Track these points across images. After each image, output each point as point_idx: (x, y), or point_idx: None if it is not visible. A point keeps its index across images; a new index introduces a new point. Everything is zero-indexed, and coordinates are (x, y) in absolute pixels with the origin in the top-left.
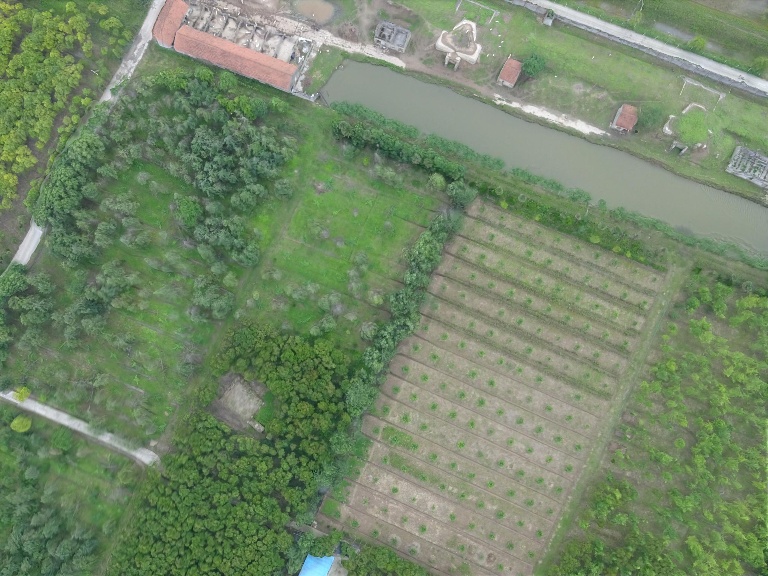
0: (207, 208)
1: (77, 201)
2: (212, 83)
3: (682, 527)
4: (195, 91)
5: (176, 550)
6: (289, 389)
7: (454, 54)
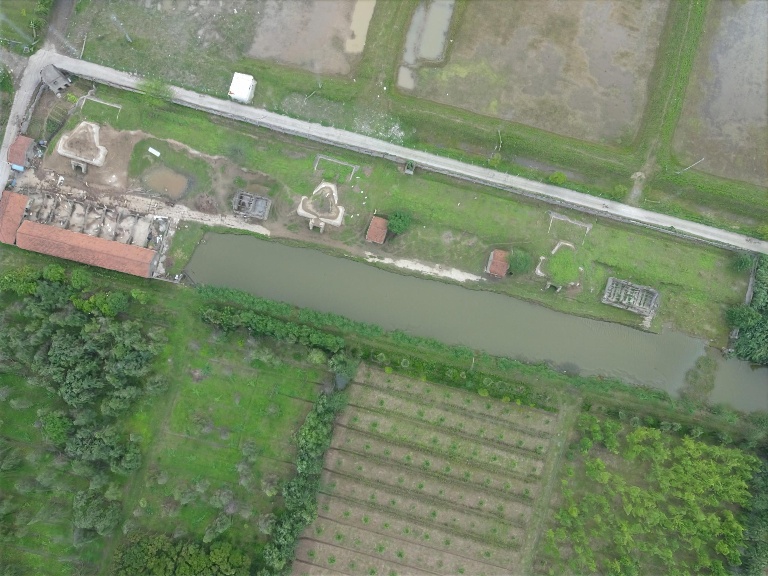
0: (75, 423)
1: None
2: (64, 280)
3: None
4: (46, 294)
5: None
6: None
7: (317, 220)
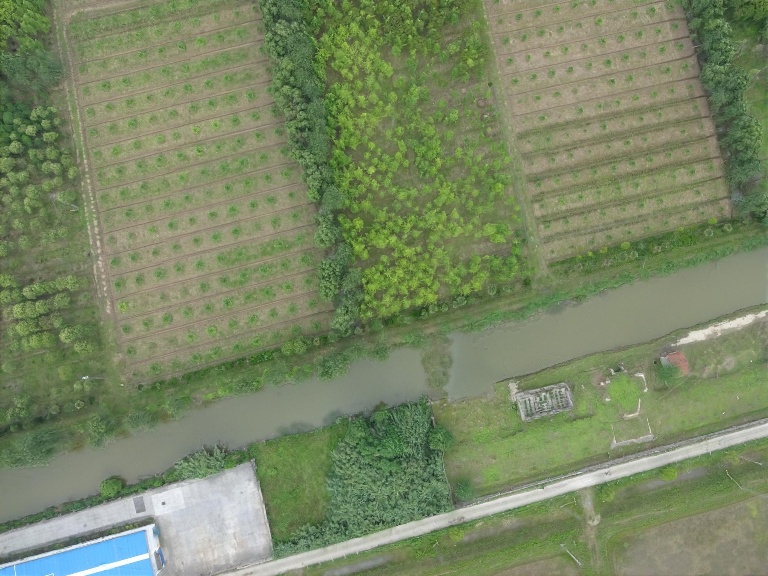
0: None
1: None
2: None
3: None
4: None
5: None
6: None
7: None
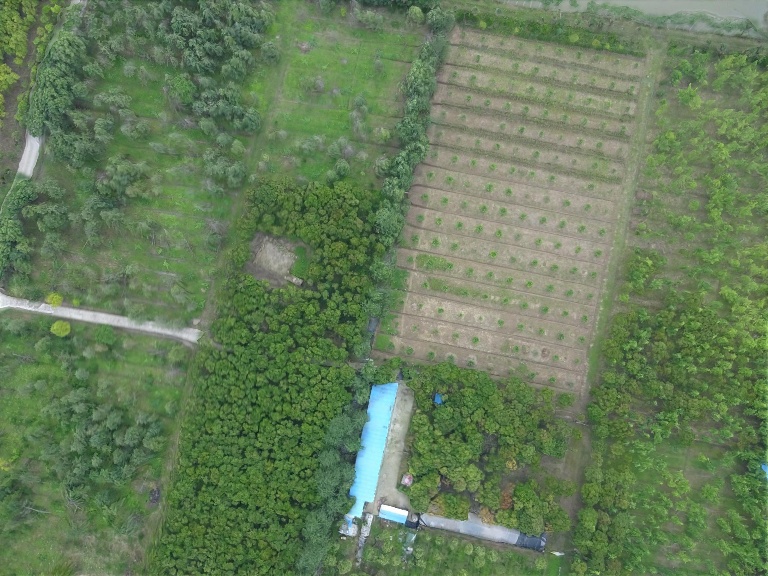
0: (201, 80)
1: (70, 101)
2: None
3: (713, 283)
4: None
5: (244, 409)
6: (319, 232)
7: None
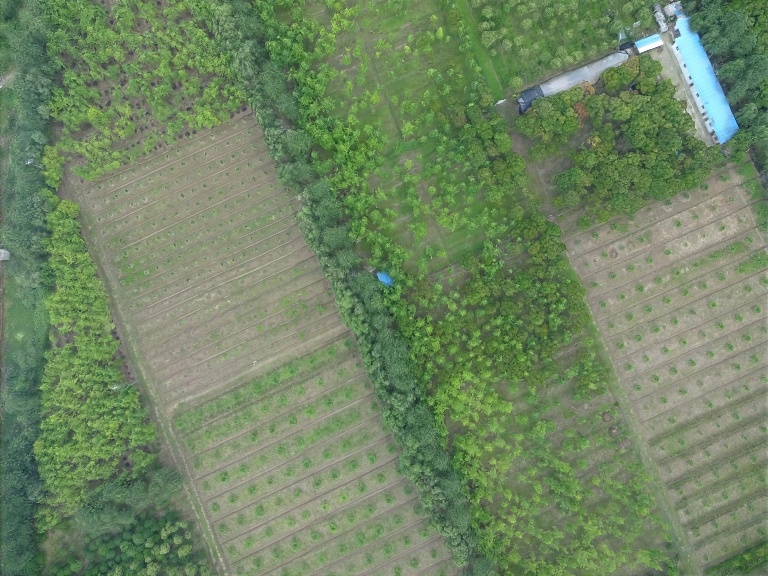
0: None
1: None
2: None
3: (518, 409)
4: None
5: None
6: None
7: None
